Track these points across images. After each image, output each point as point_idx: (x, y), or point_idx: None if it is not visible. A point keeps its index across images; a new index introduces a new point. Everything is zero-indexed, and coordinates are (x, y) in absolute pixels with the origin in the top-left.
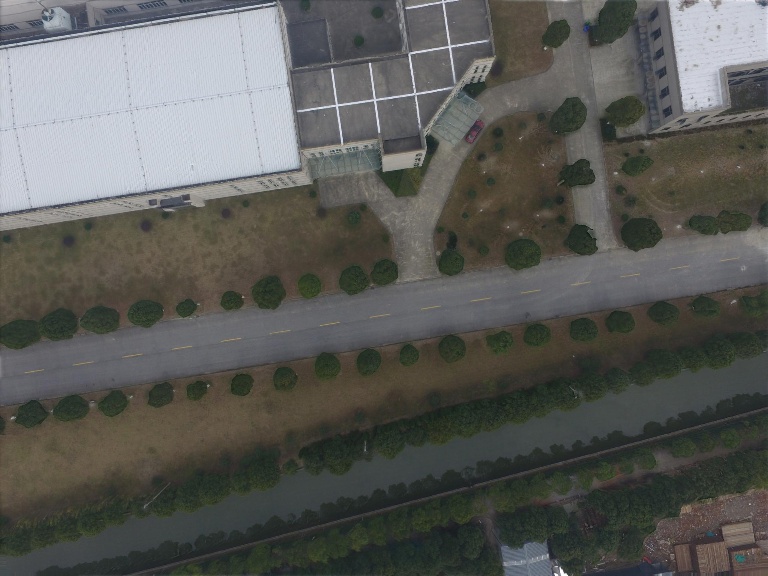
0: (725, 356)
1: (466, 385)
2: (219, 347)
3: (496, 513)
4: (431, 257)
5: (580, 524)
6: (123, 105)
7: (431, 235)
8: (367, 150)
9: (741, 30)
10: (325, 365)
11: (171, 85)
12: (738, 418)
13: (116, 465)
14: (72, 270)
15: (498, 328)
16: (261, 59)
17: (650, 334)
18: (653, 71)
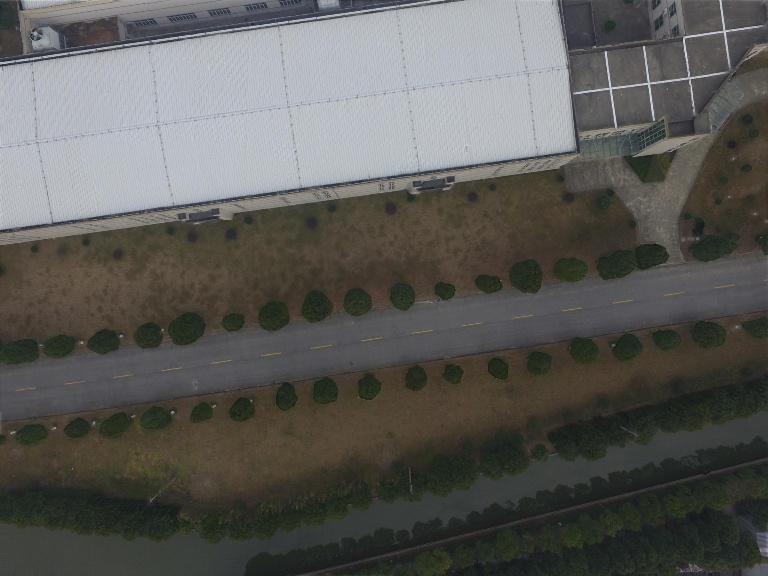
0: None
1: (709, 372)
2: (460, 332)
3: (749, 500)
4: (675, 243)
5: None
6: (399, 85)
7: (676, 221)
8: (632, 134)
9: None
10: (592, 349)
11: (448, 65)
12: None
13: (354, 450)
14: (313, 252)
15: (741, 315)
16: (539, 40)
17: None
18: None
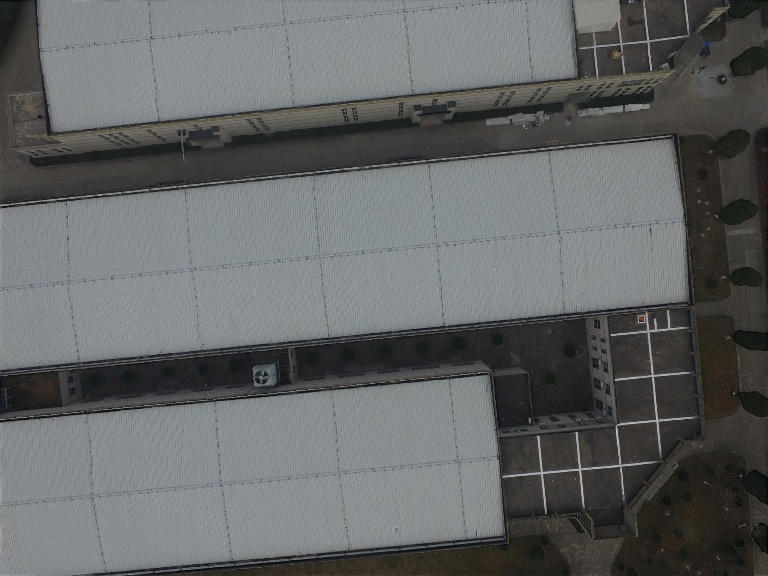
0: None
1: None
2: None
3: None
4: None
5: None
6: (331, 468)
7: (610, 569)
8: None
9: None
10: None
11: (380, 450)
12: None
13: None
14: None
15: None
16: (471, 429)
17: None
18: None
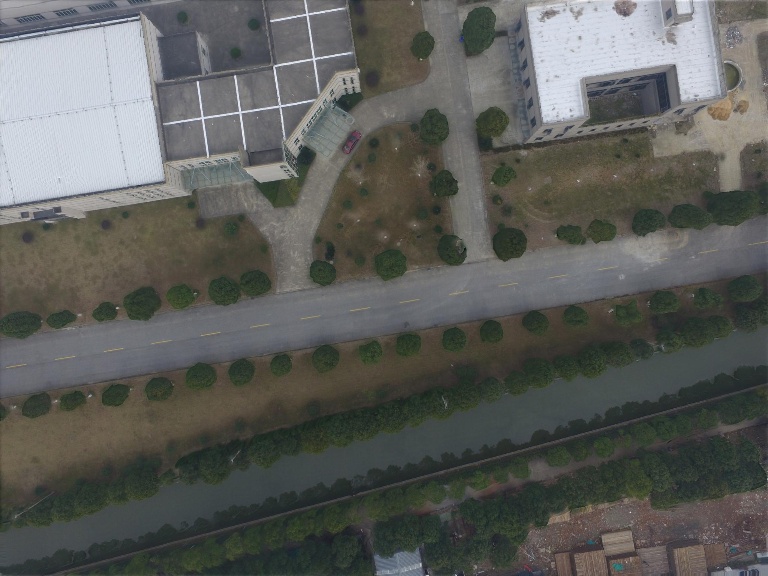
0: (594, 365)
1: (345, 394)
2: (102, 357)
3: (370, 522)
4: None
5: (450, 533)
6: None
7: (310, 245)
8: (237, 162)
9: (602, 41)
10: (194, 376)
11: (37, 99)
12: (618, 426)
13: (1, 474)
14: None
15: (377, 337)
16: (126, 73)
17: (528, 343)
18: (522, 81)
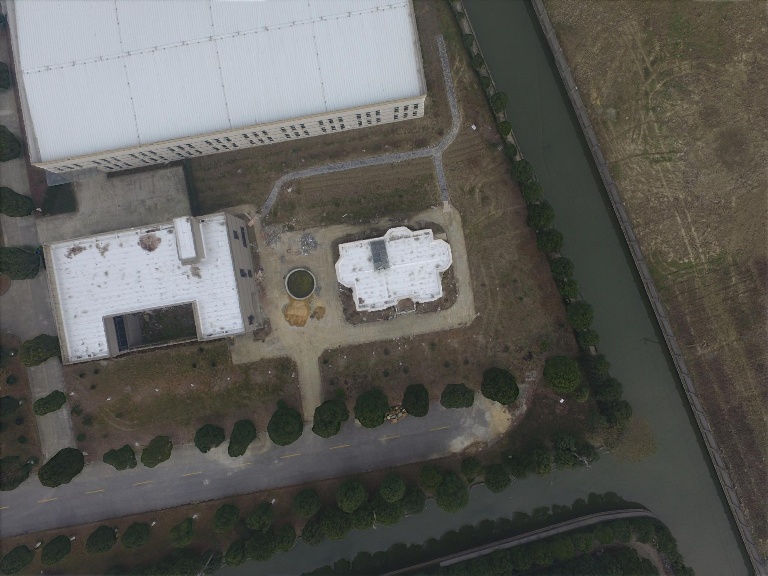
0: None
1: None
2: None
3: None
4: None
5: None
6: None
7: None
8: None
9: (128, 276)
10: None
11: None
12: None
13: None
14: None
15: None
16: None
17: (115, 549)
18: None
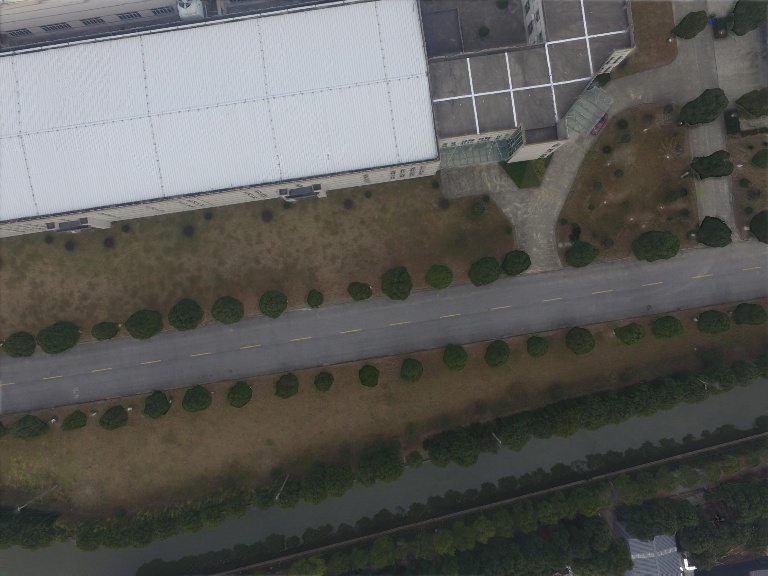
0: None
1: (588, 377)
2: (338, 338)
3: (623, 506)
4: (553, 249)
5: (710, 517)
6: (259, 93)
7: (553, 227)
8: (499, 140)
9: None
10: (458, 356)
11: (308, 73)
12: None
13: (234, 457)
14: (191, 260)
15: (620, 320)
16: (399, 48)
17: None
18: None
